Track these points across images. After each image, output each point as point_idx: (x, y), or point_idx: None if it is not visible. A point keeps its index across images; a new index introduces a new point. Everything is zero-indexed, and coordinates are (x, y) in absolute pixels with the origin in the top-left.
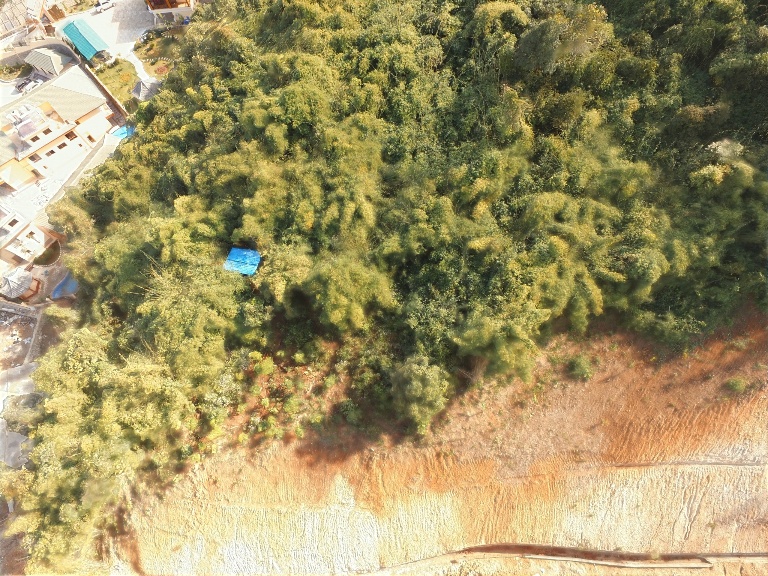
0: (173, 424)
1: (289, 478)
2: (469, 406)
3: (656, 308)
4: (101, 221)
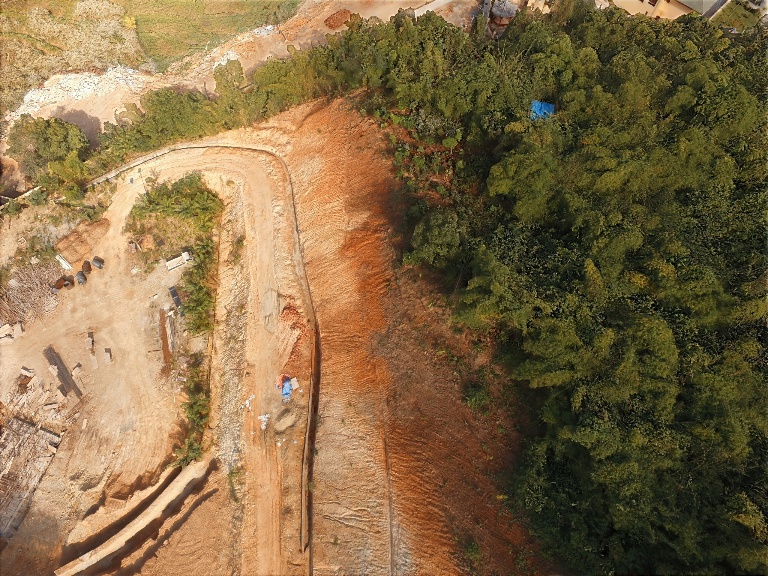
0: (399, 85)
1: (366, 181)
2: (430, 299)
3: (552, 472)
4: (566, 30)
